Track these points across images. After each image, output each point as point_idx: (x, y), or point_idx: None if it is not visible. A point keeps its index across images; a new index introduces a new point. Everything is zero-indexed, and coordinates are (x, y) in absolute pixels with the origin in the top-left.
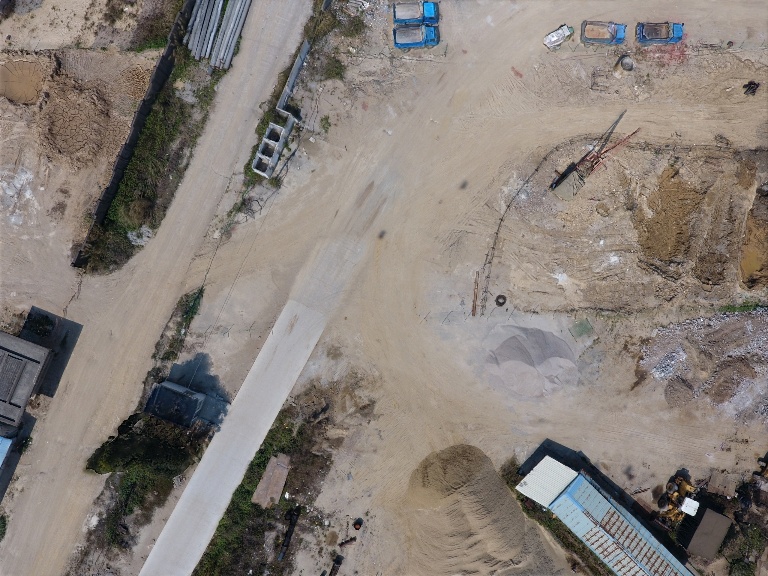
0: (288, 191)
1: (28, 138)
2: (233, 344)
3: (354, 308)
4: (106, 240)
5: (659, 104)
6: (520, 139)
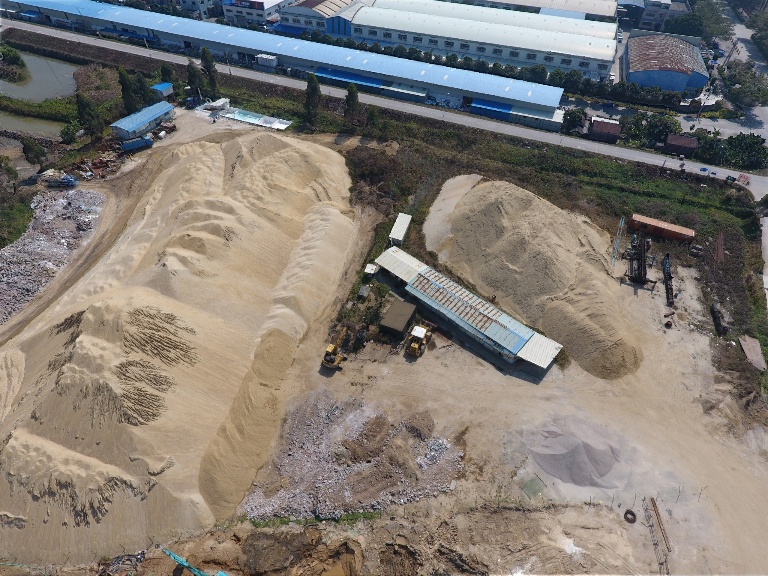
0: None
1: None
2: None
3: None
4: None
5: None
6: None
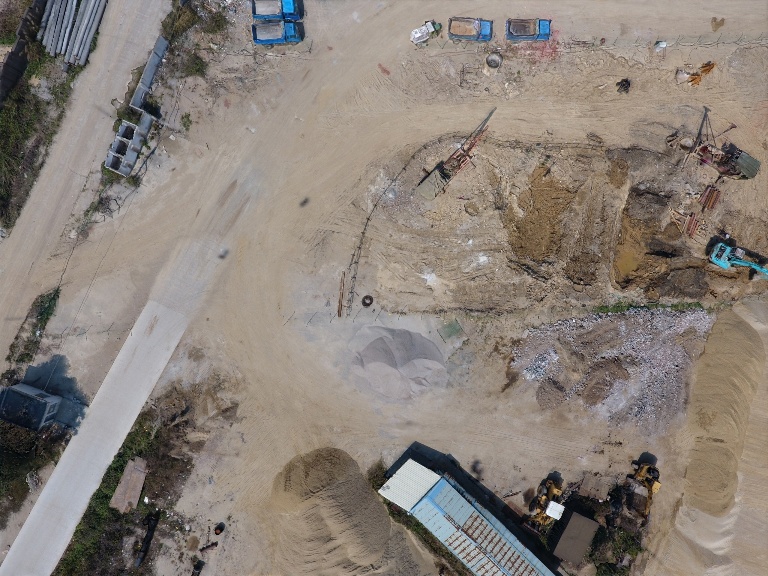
0: (147, 190)
1: None
2: (91, 346)
3: (216, 309)
4: None
5: (530, 102)
6: (387, 137)
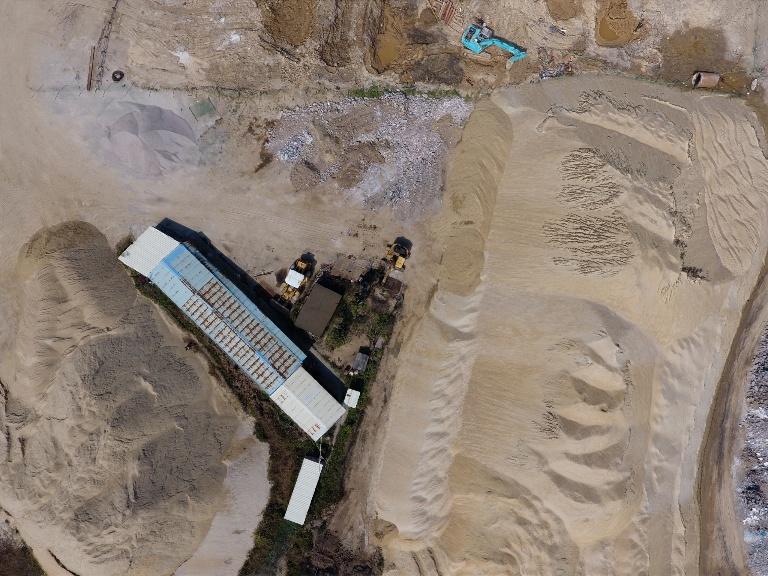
0: None
1: None
2: None
3: None
4: None
5: None
6: None
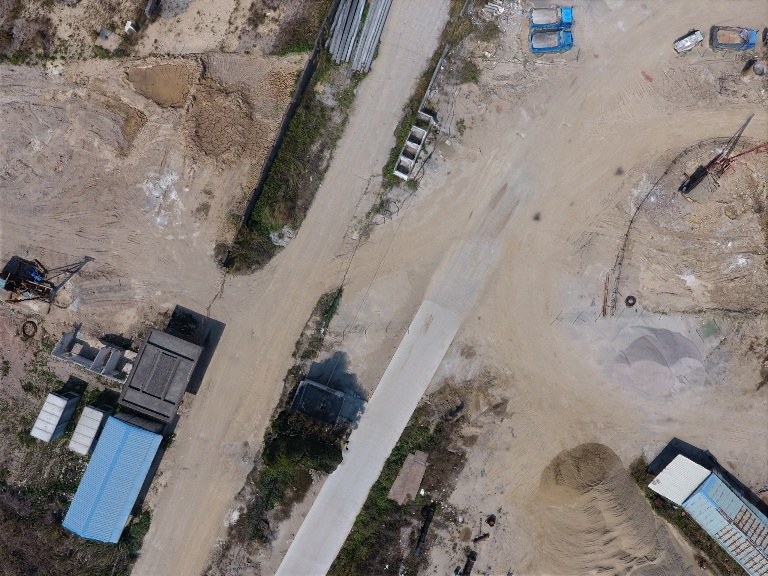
0: (424, 193)
1: (174, 140)
2: (370, 343)
3: (487, 308)
4: (250, 240)
5: None
6: (649, 142)
